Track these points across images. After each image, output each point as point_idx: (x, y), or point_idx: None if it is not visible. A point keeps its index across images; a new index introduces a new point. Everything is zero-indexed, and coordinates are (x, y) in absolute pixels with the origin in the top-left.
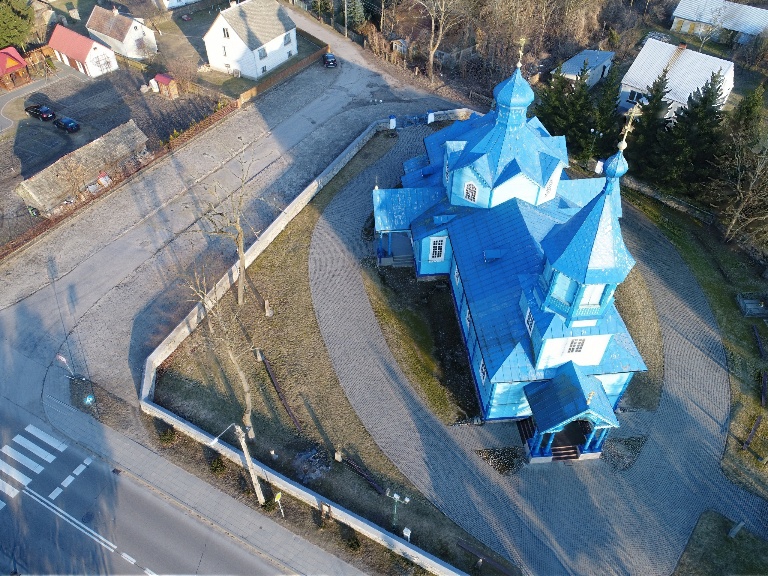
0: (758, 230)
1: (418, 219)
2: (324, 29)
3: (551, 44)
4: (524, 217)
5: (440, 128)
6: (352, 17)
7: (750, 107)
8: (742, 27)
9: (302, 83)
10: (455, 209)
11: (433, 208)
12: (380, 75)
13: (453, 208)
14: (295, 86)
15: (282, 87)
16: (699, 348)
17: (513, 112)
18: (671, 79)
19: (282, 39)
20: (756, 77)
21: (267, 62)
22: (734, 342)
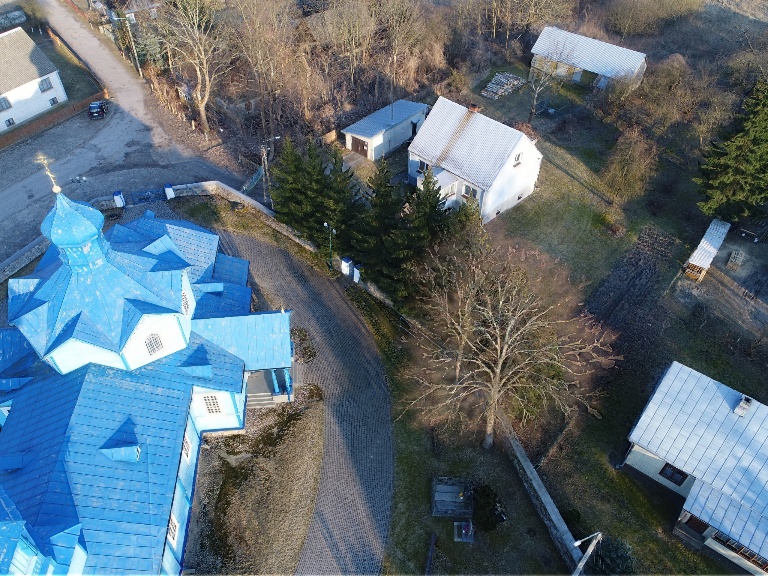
0: (440, 404)
1: (1, 375)
2: (121, 67)
3: (356, 93)
4: (80, 399)
5: (179, 206)
6: (144, 55)
7: (464, 221)
8: (602, 69)
9: (50, 140)
10: (37, 367)
11: (22, 360)
12: (150, 130)
13: (37, 365)
14: (39, 144)
15: (22, 146)
16: (344, 574)
17: (70, 250)
18: (458, 149)
19: (36, 85)
20: (606, 132)
21: (14, 114)
22: (398, 563)
